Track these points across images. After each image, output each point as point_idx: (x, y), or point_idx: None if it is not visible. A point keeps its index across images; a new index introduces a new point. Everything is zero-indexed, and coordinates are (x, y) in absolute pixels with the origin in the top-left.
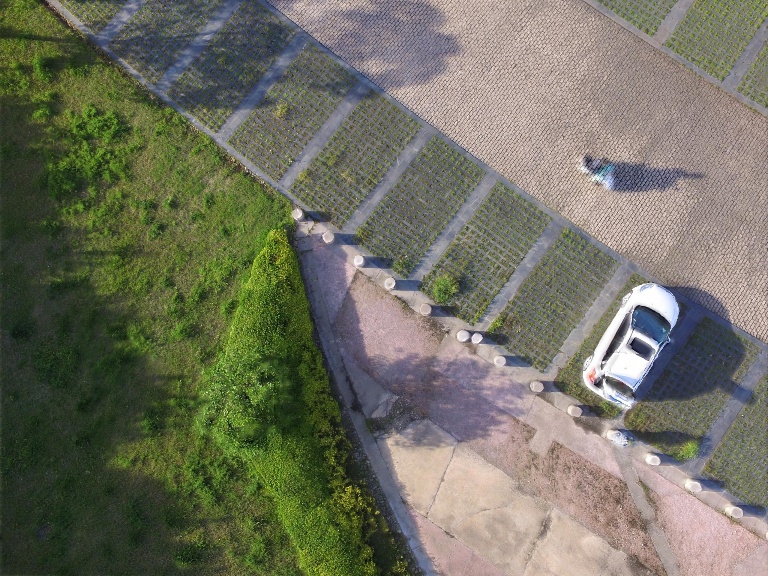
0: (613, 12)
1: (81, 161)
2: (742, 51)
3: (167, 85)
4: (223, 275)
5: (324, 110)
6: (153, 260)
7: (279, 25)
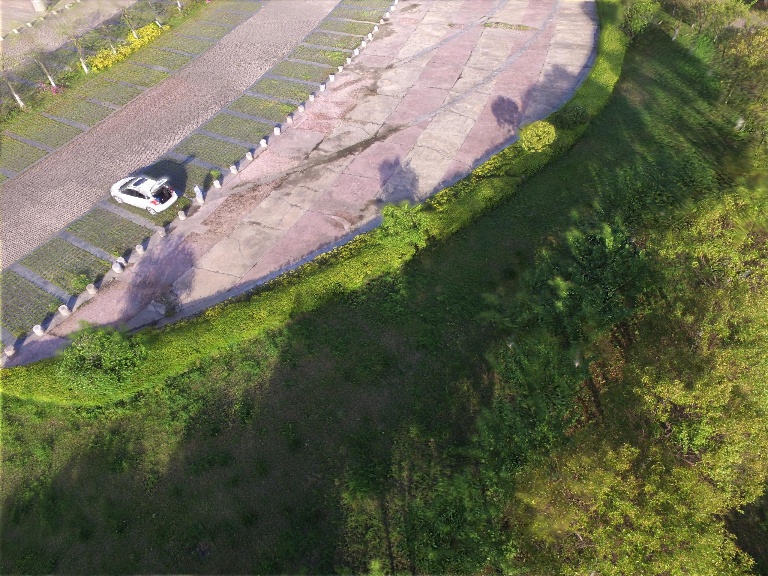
0: None
1: None
2: None
3: None
4: (7, 425)
5: None
6: None
7: None
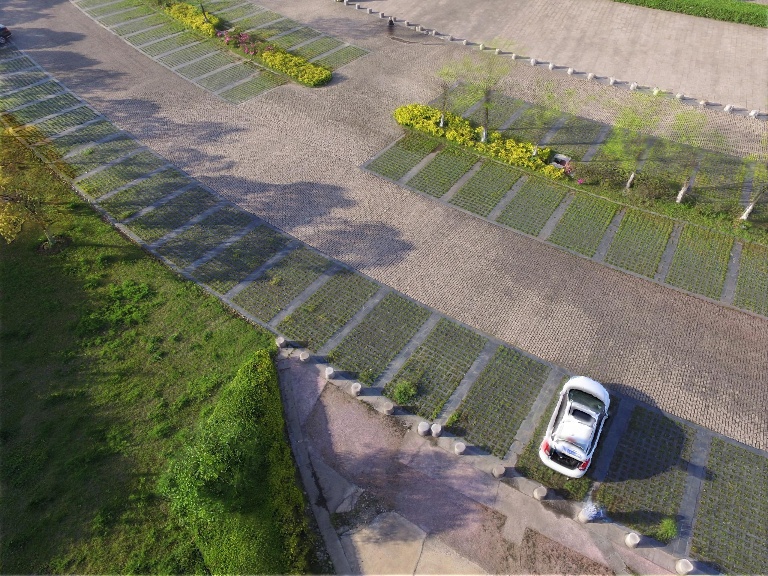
0: (508, 226)
1: (110, 313)
2: (599, 242)
3: (193, 269)
4: (208, 388)
5: (308, 280)
6: (148, 378)
7: (281, 237)
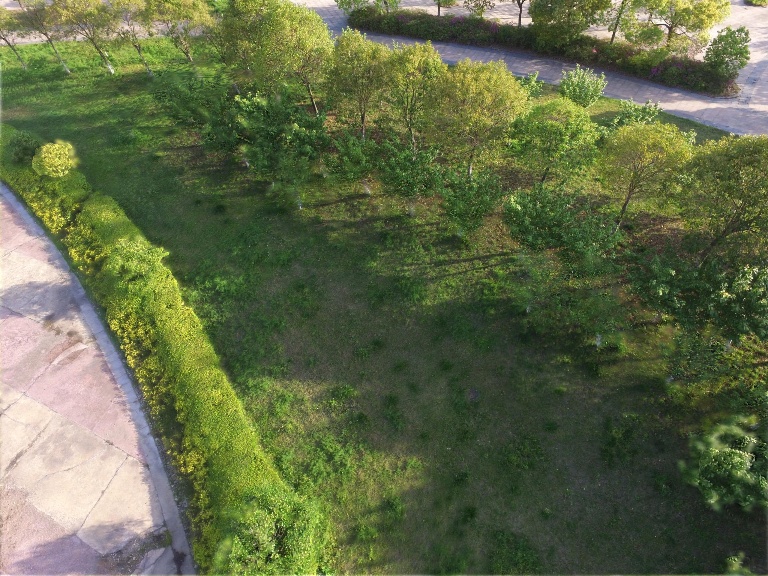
0: None
1: None
2: None
3: None
4: None
5: None
6: None
7: None
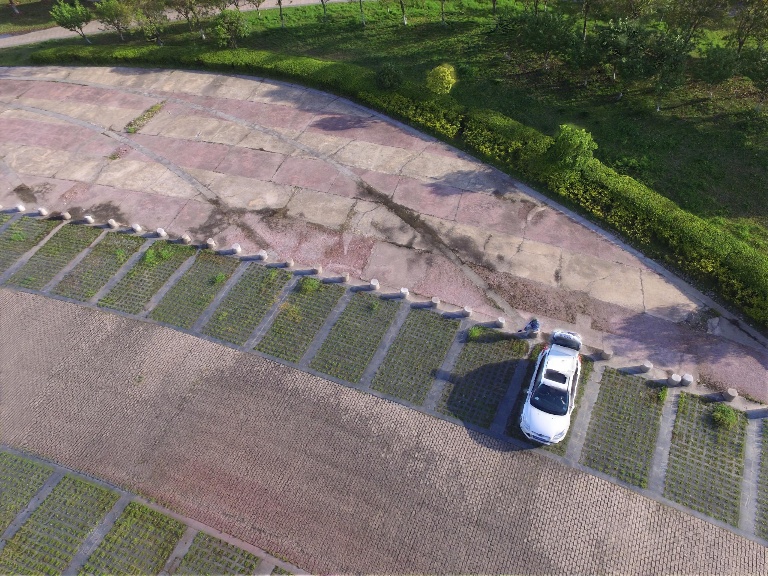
0: None
1: None
2: None
3: None
4: None
5: None
6: None
7: None
